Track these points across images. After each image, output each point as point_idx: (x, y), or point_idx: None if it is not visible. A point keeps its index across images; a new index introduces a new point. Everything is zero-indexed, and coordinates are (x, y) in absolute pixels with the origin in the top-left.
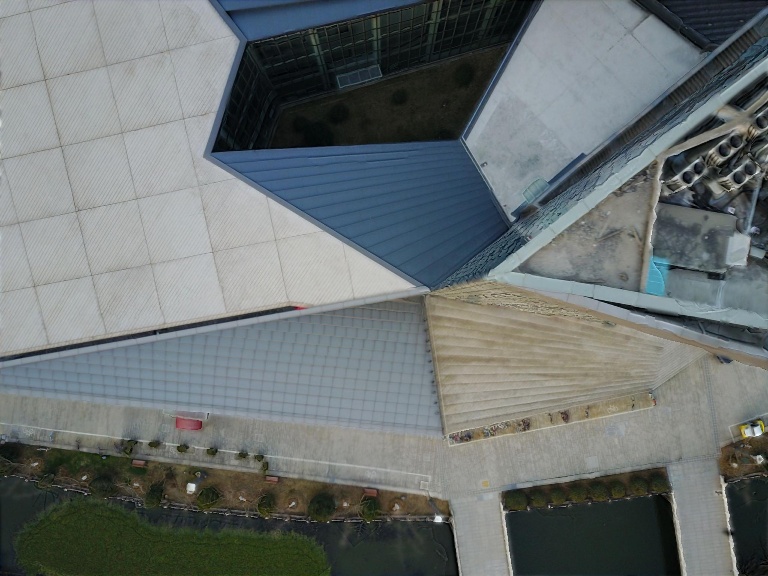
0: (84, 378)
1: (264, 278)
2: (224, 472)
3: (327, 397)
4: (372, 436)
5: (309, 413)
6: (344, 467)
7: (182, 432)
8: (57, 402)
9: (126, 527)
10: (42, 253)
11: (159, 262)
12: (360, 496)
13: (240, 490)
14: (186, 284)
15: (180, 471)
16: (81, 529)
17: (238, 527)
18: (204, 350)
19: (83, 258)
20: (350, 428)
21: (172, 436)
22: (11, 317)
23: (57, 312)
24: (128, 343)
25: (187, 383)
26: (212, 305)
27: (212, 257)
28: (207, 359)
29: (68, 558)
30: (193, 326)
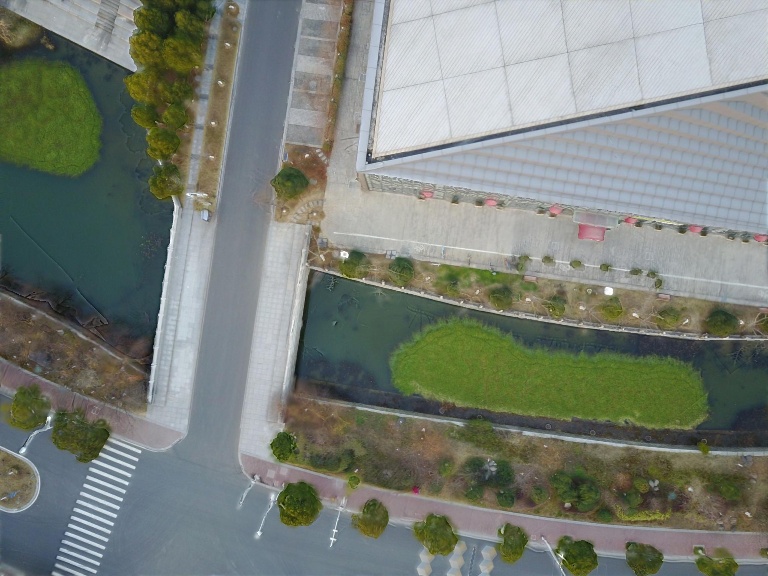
0: (527, 169)
1: (758, 47)
2: (614, 290)
3: (750, 201)
4: (766, 256)
5: (731, 217)
6: (737, 286)
7: (572, 250)
8: (447, 219)
9: (502, 349)
10: (517, 31)
11: (643, 35)
12: (754, 315)
13: (632, 307)
14: (671, 57)
15: (570, 288)
16: (458, 350)
17: (614, 351)
18: (658, 138)
19: (560, 35)
20: (743, 247)
21: (562, 253)
22: (475, 99)
23: (526, 92)
24: (601, 121)
25: (622, 179)
26: (697, 78)
27: (702, 28)
28: (653, 150)
29: (445, 378)
30: (673, 101)
